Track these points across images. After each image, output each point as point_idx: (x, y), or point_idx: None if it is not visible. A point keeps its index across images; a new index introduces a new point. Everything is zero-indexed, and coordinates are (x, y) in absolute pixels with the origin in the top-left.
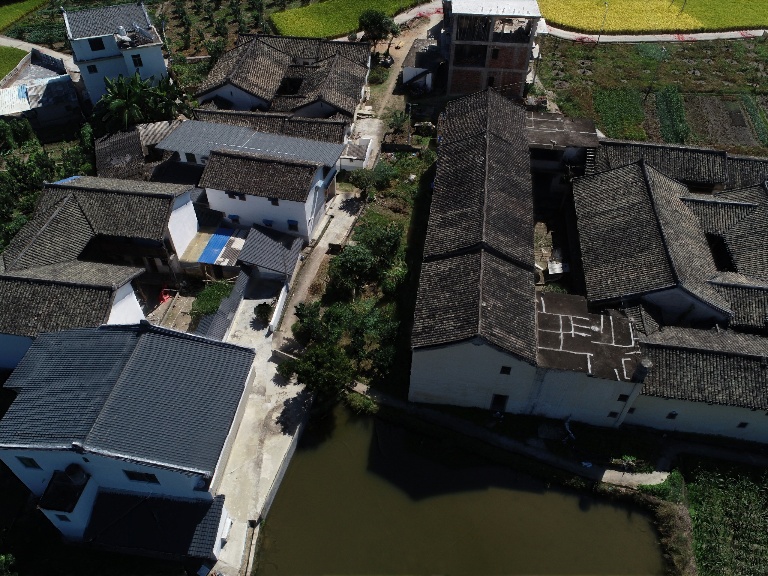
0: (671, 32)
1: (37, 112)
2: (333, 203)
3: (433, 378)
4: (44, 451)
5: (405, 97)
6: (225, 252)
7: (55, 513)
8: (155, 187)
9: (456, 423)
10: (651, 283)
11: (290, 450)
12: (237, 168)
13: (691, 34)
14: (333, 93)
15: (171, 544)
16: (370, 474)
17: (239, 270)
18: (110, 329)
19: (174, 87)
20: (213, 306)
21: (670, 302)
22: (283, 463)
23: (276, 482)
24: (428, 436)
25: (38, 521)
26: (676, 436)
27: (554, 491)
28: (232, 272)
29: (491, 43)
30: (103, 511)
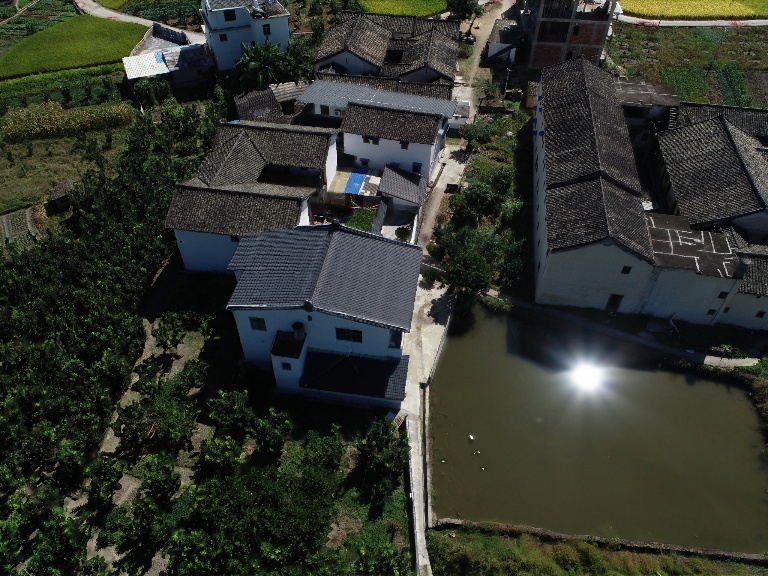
0: (725, 18)
1: (174, 75)
2: (443, 153)
3: (561, 279)
4: (277, 310)
5: (491, 69)
6: (365, 186)
7: (282, 361)
8: (309, 128)
9: (577, 320)
10: (740, 209)
11: (445, 334)
12: (372, 116)
13: (743, 20)
14: (435, 61)
15: (371, 389)
16: (511, 355)
17: (378, 200)
18: (305, 229)
19: (300, 53)
20: (364, 226)
21: (756, 225)
22: (442, 342)
23: (438, 356)
24: (554, 329)
25: (259, 373)
26: (762, 334)
27: (664, 371)
28: (372, 202)
29: (573, 20)
30: (313, 365)
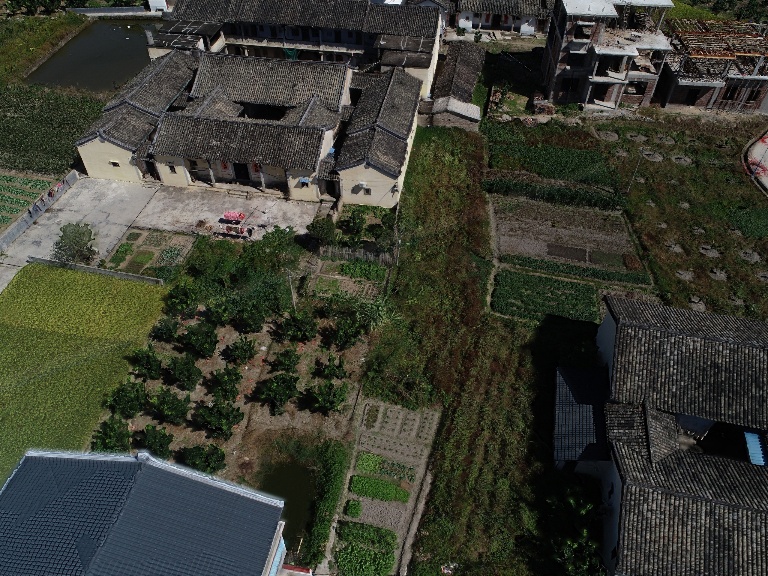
0: None
1: None
2: None
3: None
4: None
5: None
6: None
7: None
8: None
9: None
10: None
11: None
12: None
13: None
14: None
15: None
16: None
17: None
18: None
19: None
20: None
21: None
22: None
23: None
24: None
25: None
26: None
27: None
28: None
29: None
30: None
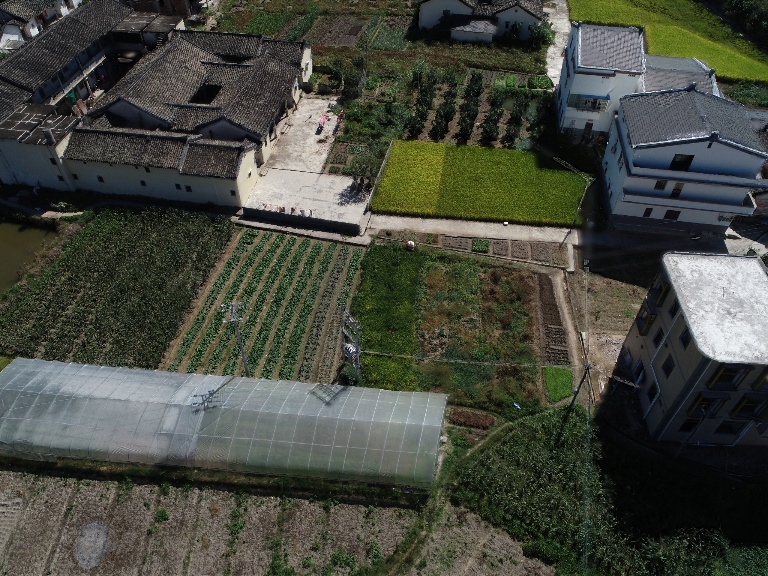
0: None
1: None
2: None
3: None
4: None
5: None
6: None
7: None
8: None
9: None
10: None
11: None
12: None
13: None
14: (15, 6)
15: None
16: None
17: None
18: None
19: None
20: None
21: (127, 113)
22: None
23: None
24: None
25: None
26: (113, 197)
27: (8, 223)
28: None
29: None
30: None
